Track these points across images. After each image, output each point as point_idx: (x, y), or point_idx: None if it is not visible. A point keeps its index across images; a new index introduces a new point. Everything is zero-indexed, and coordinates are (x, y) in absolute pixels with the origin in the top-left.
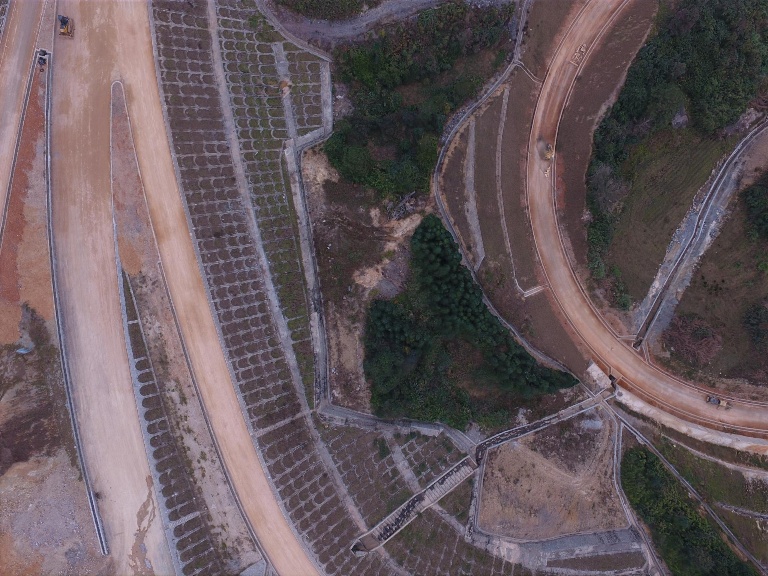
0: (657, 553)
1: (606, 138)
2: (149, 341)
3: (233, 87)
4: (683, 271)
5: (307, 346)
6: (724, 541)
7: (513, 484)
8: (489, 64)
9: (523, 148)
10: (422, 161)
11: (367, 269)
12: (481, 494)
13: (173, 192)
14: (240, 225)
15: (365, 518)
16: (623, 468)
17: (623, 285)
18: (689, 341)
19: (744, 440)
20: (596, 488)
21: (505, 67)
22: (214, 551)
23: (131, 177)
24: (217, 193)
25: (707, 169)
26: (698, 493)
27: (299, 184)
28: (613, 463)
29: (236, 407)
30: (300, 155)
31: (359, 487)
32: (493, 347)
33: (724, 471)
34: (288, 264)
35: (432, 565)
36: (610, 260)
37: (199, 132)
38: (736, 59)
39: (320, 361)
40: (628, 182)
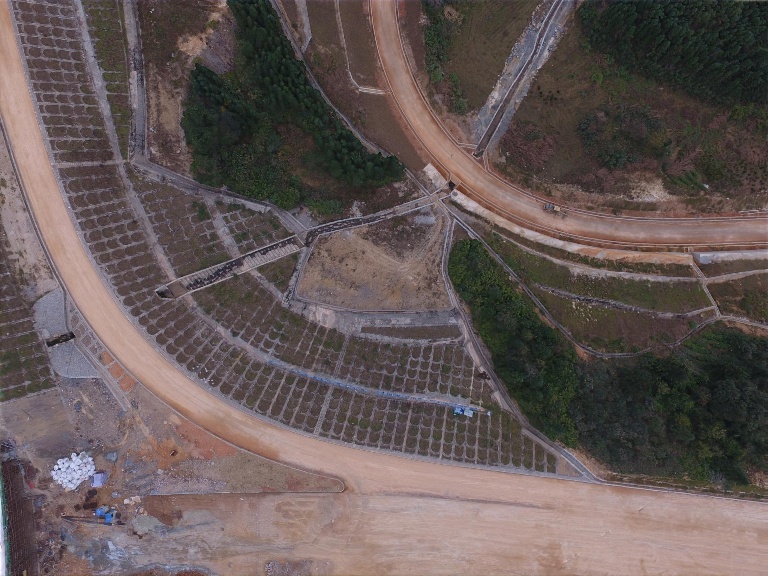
0: (475, 329)
1: None
2: None
3: None
4: (522, 84)
5: (123, 100)
6: (535, 312)
7: (338, 263)
8: None
9: None
10: None
11: (191, 37)
12: (304, 268)
13: None
14: None
15: (175, 268)
16: (450, 256)
17: (461, 91)
18: (521, 143)
19: (576, 244)
20: (423, 274)
21: None
22: (11, 276)
23: None
24: None
25: None
26: (518, 276)
27: None
28: (442, 253)
29: (39, 138)
30: None
31: (171, 239)
32: (322, 130)
33: (550, 265)
34: (108, 21)
35: (242, 319)
36: (450, 69)
37: None
38: None
39: (137, 116)
40: None
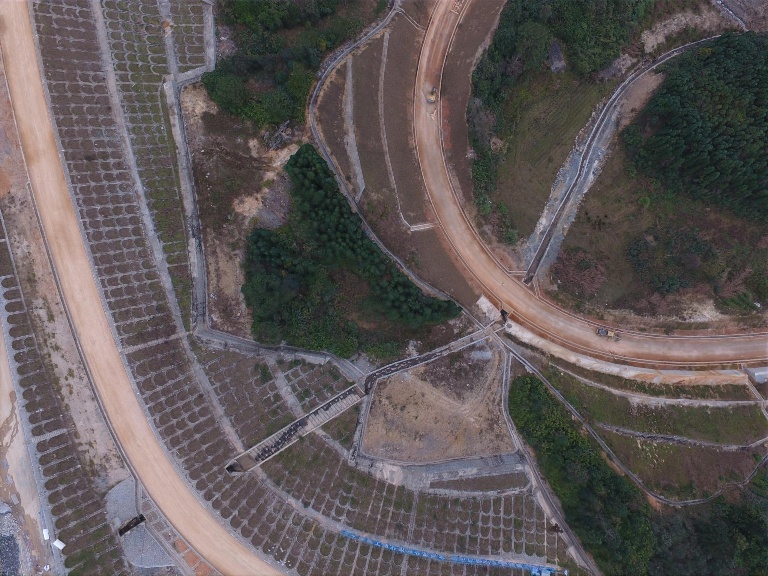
0: (541, 474)
1: (481, 76)
2: (17, 260)
3: (110, 23)
4: (569, 209)
5: (184, 270)
6: (603, 458)
7: (400, 411)
8: (371, 10)
9: (409, 92)
10: (290, 88)
11: (246, 198)
12: (367, 420)
13: (43, 116)
14: (115, 151)
15: (242, 439)
16: (510, 395)
17: (510, 221)
18: (573, 272)
19: (632, 369)
20: (484, 415)
21: (386, 13)
22: (81, 468)
23: (1, 102)
24: (90, 120)
25: (587, 111)
26: (581, 415)
27: (178, 116)
28: (501, 391)
29: (105, 324)
30: (180, 90)
31: (237, 409)
32: (378, 277)
33: (610, 397)
34: (165, 191)
35: (311, 486)
36: (497, 198)
37: (73, 62)
38: (604, 6)
39: (197, 285)
40: (511, 123)
